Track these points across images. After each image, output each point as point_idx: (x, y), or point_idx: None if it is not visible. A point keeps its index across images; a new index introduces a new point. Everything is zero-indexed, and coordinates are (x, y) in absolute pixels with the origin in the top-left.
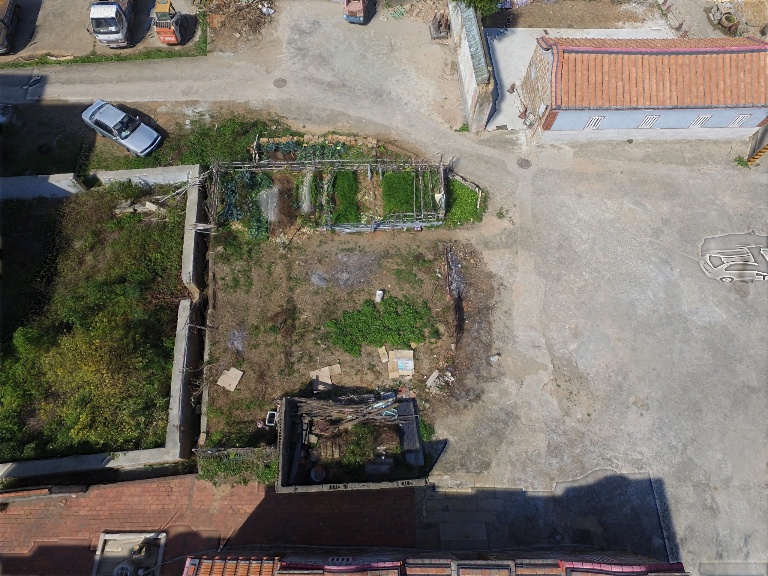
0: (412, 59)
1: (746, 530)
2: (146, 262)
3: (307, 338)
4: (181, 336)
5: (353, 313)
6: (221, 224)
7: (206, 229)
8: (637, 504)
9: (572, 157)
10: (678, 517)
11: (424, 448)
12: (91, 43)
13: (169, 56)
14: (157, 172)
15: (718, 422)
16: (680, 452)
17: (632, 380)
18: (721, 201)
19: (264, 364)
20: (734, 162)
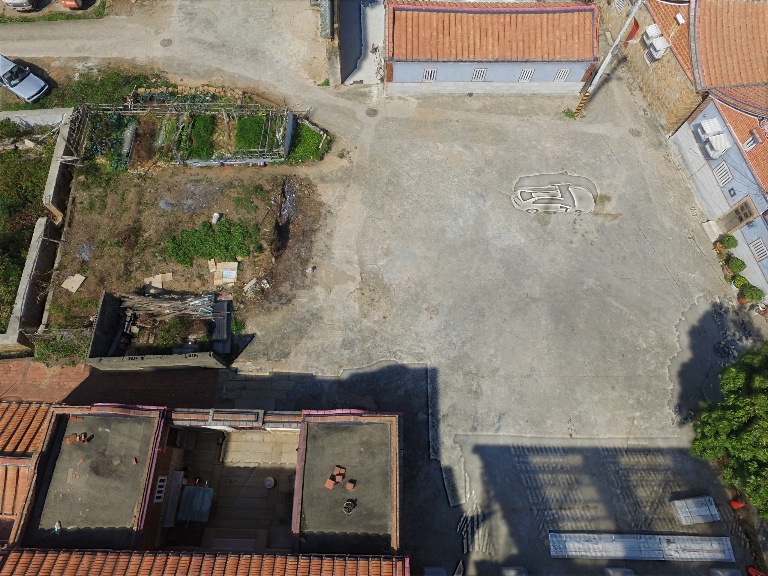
0: (290, 23)
1: (502, 410)
2: (17, 188)
3: (147, 251)
4: (34, 246)
5: (190, 231)
6: (87, 158)
7: (71, 161)
8: (411, 388)
9: (415, 107)
10: (444, 398)
11: (233, 340)
12: (1, 7)
13: (69, 18)
14: (35, 113)
15: (497, 325)
16: (458, 348)
17: (429, 290)
18: (542, 146)
19: (105, 271)
20: (562, 114)
